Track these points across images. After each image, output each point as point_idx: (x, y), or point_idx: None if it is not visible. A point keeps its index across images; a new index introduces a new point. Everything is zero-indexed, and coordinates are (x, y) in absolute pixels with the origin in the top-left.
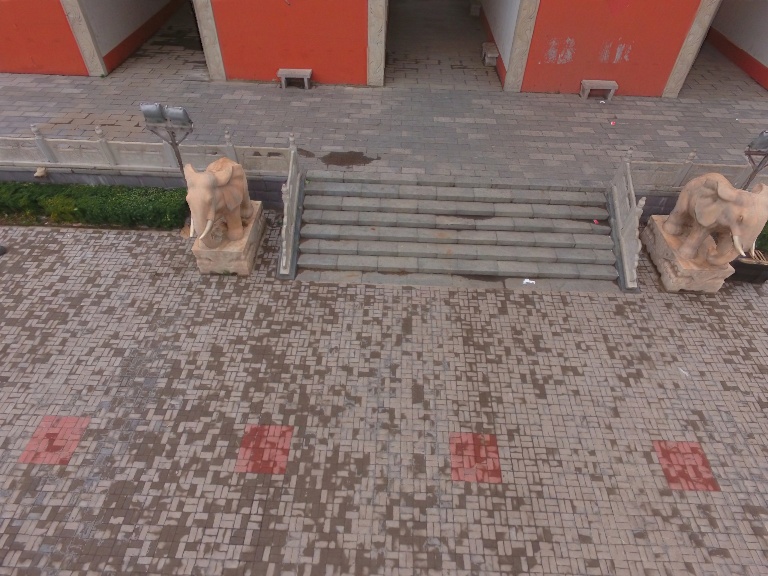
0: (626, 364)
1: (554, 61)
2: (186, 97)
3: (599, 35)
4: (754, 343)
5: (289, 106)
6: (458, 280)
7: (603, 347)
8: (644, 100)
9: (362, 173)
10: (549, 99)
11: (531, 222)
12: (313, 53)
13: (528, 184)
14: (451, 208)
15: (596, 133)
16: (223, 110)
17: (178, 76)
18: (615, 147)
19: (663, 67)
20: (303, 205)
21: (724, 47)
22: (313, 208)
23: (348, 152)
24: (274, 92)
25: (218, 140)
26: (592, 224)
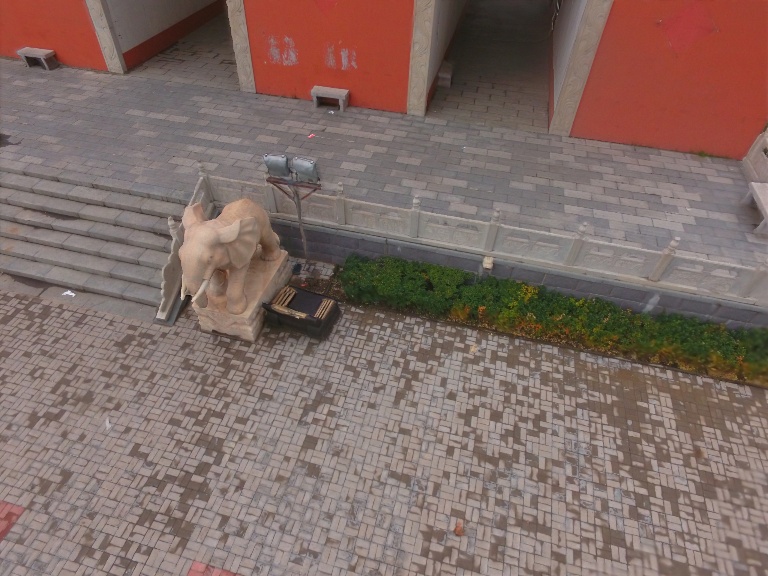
0: (57, 402)
1: (280, 62)
2: None
3: (318, 36)
4: (229, 407)
5: (8, 84)
6: (3, 280)
7: (57, 378)
8: (382, 115)
9: None
10: (276, 103)
11: (109, 230)
12: (50, 34)
13: (127, 188)
14: (38, 203)
15: (277, 144)
16: None
17: None
18: None
19: (398, 79)
20: None
21: None
22: None
23: None
24: (14, 70)
25: None
26: (170, 241)
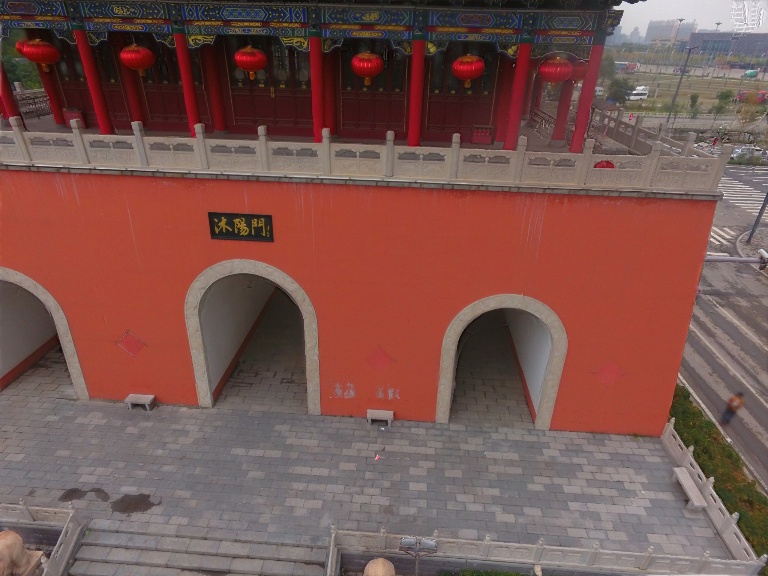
0: None
1: (342, 396)
2: (47, 421)
3: (372, 382)
4: None
5: (123, 433)
6: None
7: None
8: (419, 426)
9: (135, 523)
10: (340, 425)
11: None
12: (155, 385)
13: (265, 540)
14: (194, 564)
15: (356, 471)
16: (67, 438)
17: (55, 393)
18: (363, 490)
19: (429, 403)
20: (75, 557)
21: (516, 359)
22: (83, 559)
23: (139, 495)
24: (120, 414)
25: (42, 478)
26: None
